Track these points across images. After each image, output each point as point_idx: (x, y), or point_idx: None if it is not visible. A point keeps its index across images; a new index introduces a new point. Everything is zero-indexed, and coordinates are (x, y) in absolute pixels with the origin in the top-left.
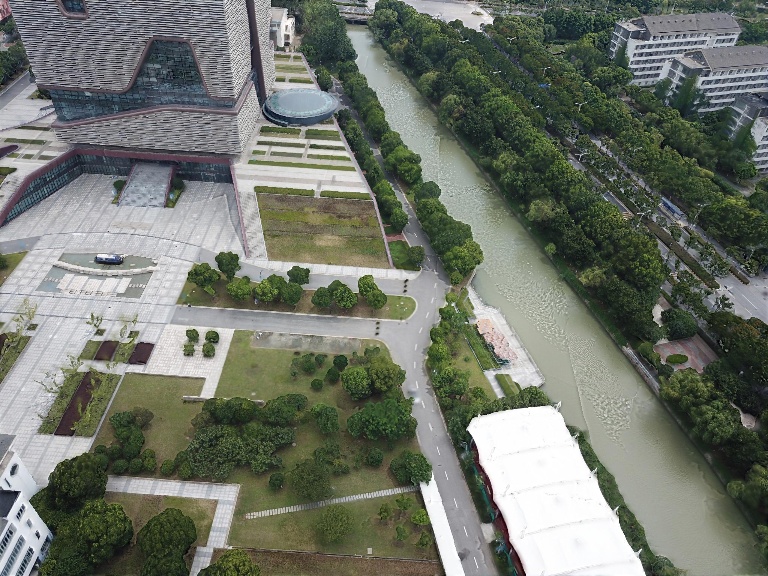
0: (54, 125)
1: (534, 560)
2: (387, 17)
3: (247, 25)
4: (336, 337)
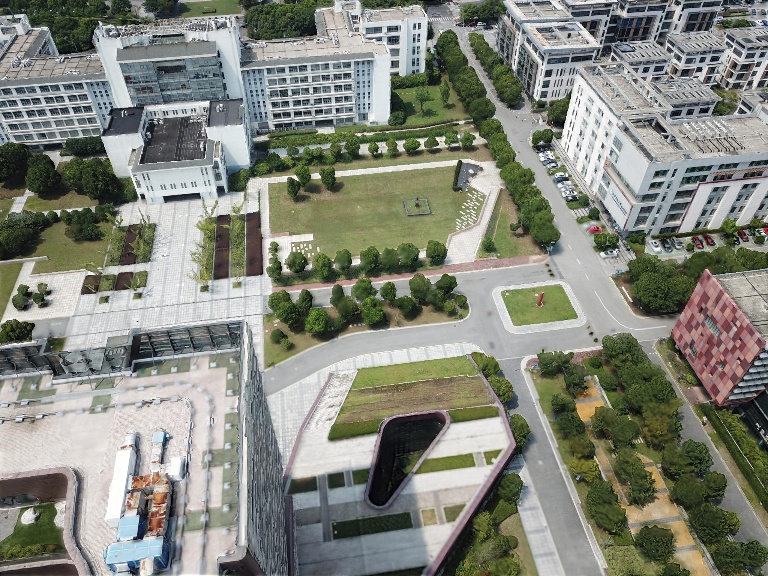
0: (284, 496)
1: None
2: None
3: None
4: None
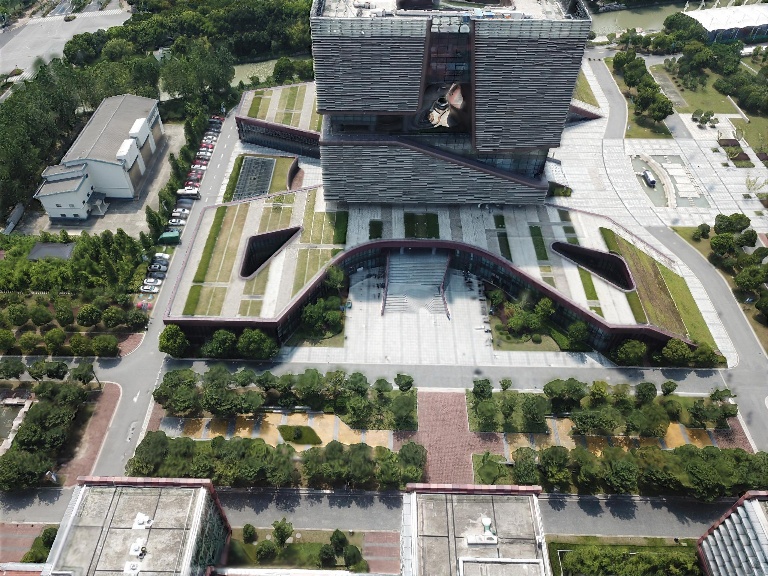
0: None
1: (764, 20)
2: (128, 46)
3: None
4: (657, 80)
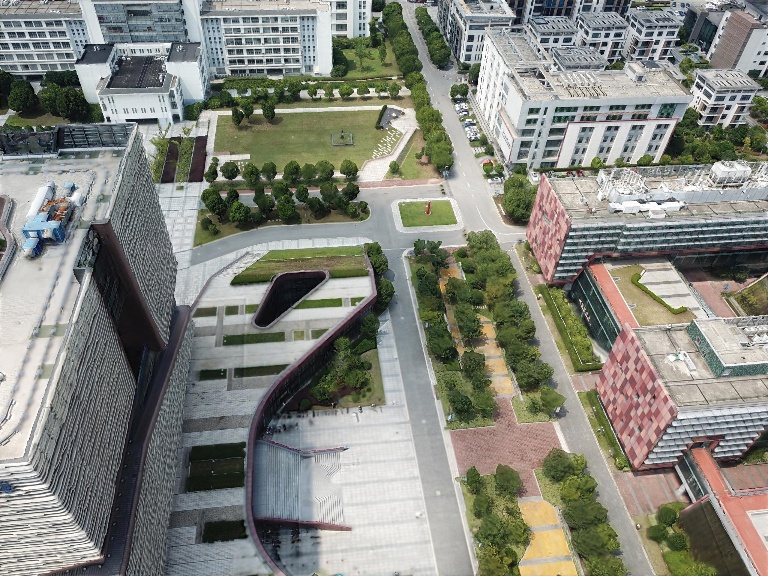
0: None
1: None
2: None
3: None
4: None
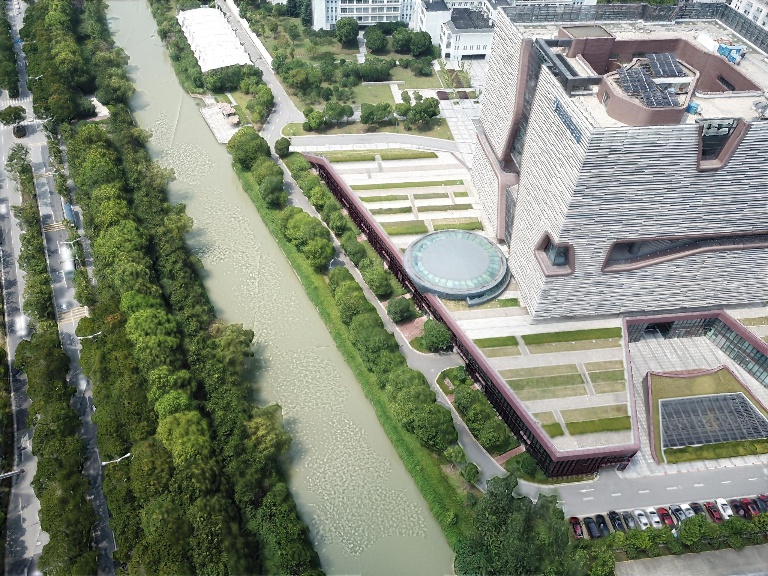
0: None
1: None
2: None
3: (512, 112)
4: None
